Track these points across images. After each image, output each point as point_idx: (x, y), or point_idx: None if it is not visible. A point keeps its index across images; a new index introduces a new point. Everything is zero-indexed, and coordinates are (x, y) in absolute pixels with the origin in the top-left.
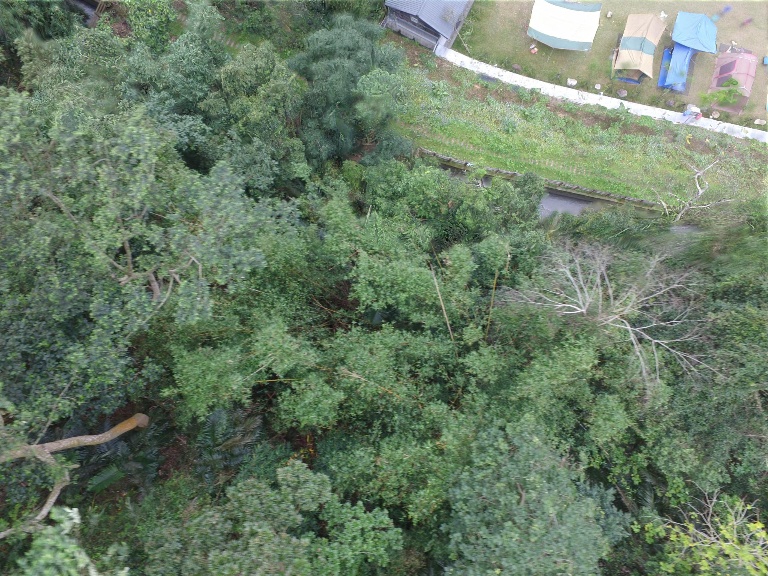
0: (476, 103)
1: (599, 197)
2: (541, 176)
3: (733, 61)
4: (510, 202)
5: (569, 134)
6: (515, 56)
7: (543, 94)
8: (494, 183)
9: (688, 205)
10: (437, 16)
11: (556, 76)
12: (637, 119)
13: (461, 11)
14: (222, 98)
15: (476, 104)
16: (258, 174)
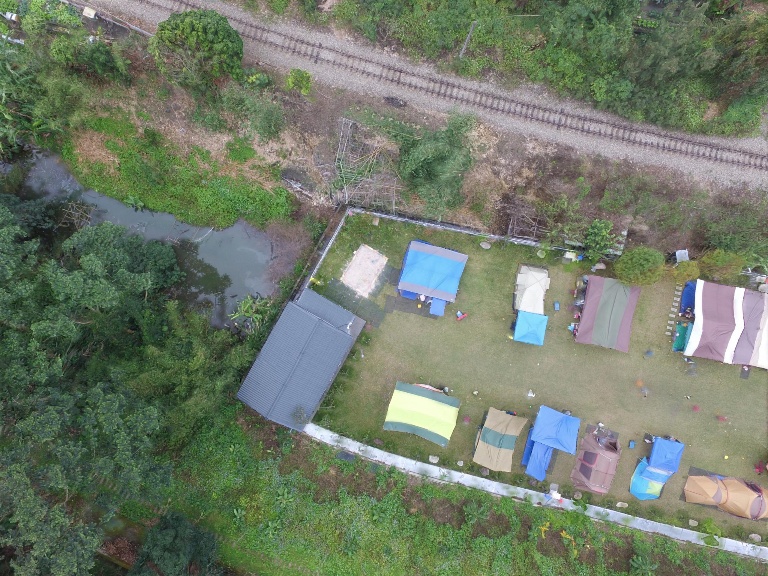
0: (324, 506)
1: None
2: None
3: (595, 454)
4: None
5: (416, 543)
6: (377, 430)
7: (403, 472)
8: None
9: None
10: (289, 414)
11: (417, 455)
12: (495, 505)
13: (316, 404)
14: None
15: (323, 508)
16: None
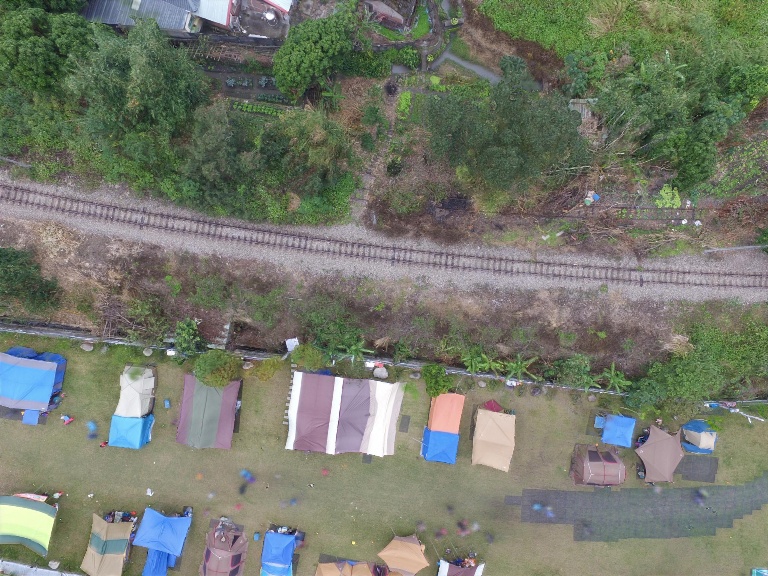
0: None
1: None
2: None
3: (209, 551)
4: None
5: None
6: None
7: None
8: None
9: None
10: None
11: (34, 562)
12: None
13: None
14: None
15: None
16: None
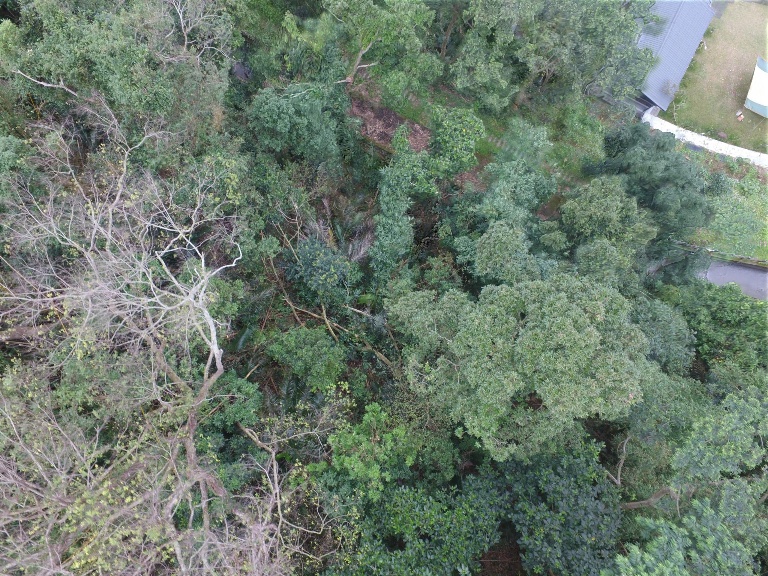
0: None
1: None
2: None
3: None
4: None
5: None
6: (721, 123)
7: (749, 163)
8: None
9: None
10: (657, 89)
11: (763, 145)
12: None
13: (679, 82)
14: (559, 230)
15: None
16: (673, 343)
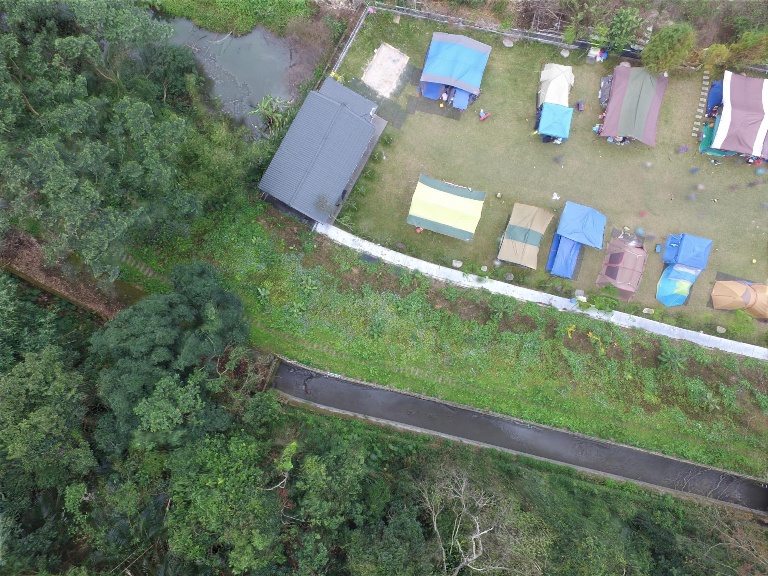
0: (348, 297)
1: (464, 408)
2: (360, 455)
3: (621, 253)
4: (310, 508)
5: (441, 333)
6: (400, 234)
7: (426, 276)
8: (306, 469)
9: (466, 562)
10: (311, 203)
11: (440, 258)
12: (520, 307)
13: (338, 196)
14: None
15: (347, 298)
16: None
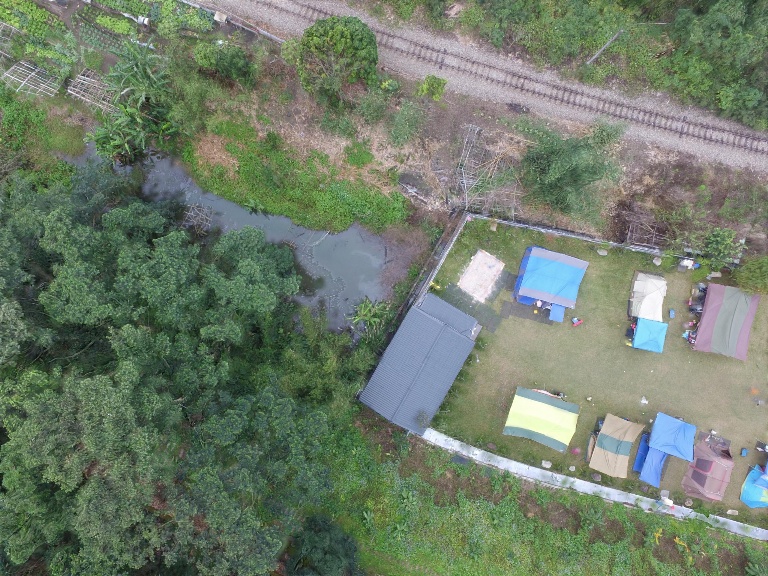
0: (445, 509)
1: None
2: None
3: (710, 461)
4: None
5: (536, 548)
6: (491, 434)
7: (516, 476)
8: None
9: None
10: (412, 418)
11: (531, 459)
12: (608, 511)
13: (437, 408)
14: None
15: (445, 511)
16: None
